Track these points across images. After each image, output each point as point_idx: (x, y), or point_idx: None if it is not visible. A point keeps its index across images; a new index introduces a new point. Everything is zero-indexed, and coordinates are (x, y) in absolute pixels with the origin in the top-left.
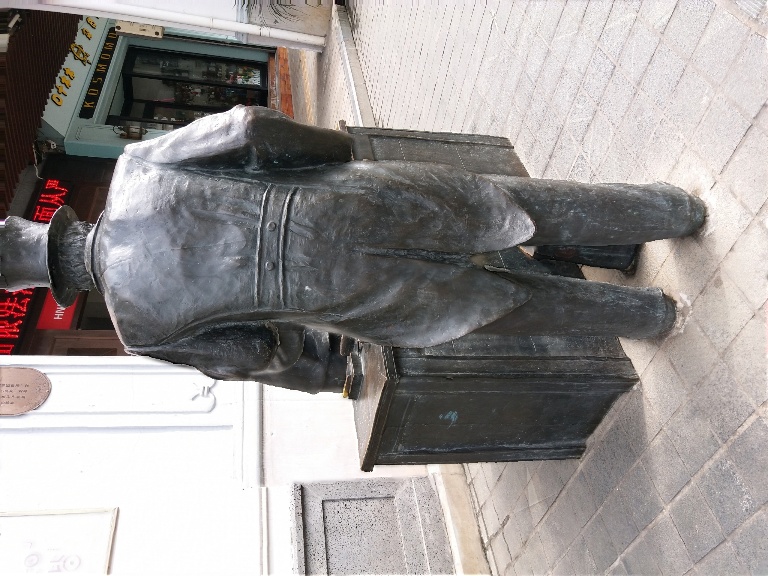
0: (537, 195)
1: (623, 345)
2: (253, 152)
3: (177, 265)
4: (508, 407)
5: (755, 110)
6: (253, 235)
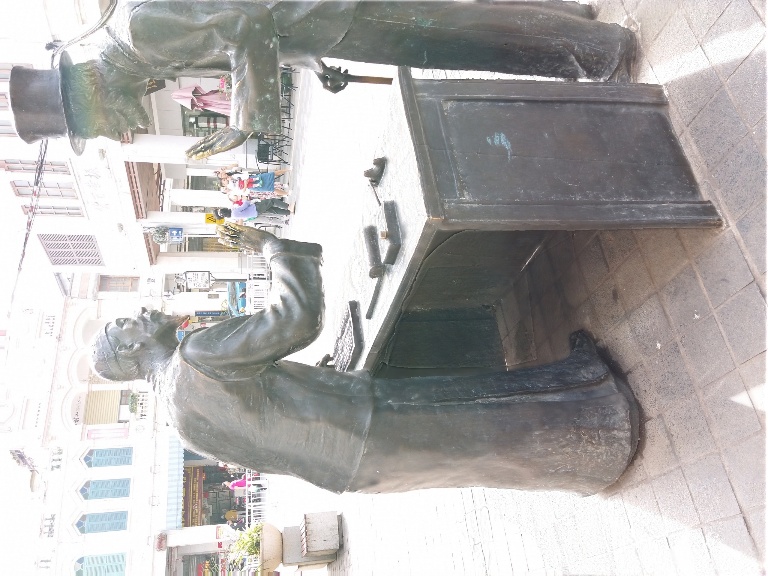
0: None
1: None
2: None
3: None
4: (559, 131)
5: None
6: None
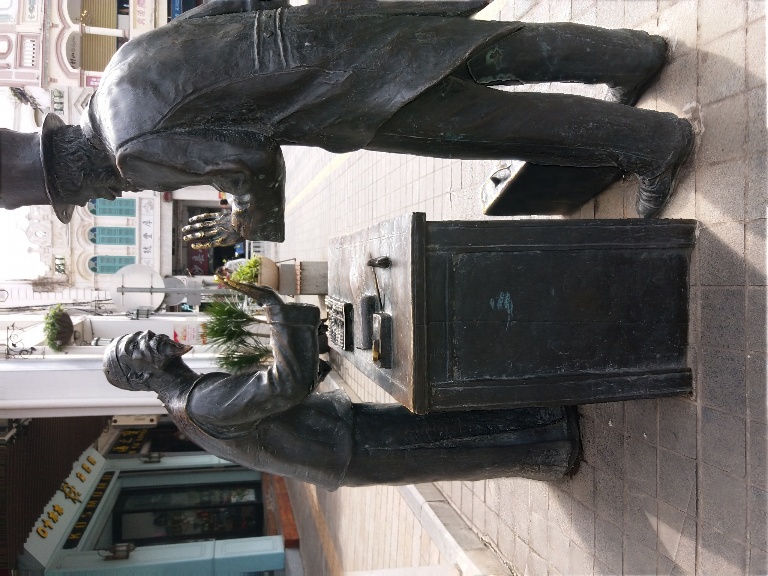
0: None
1: None
2: (247, 2)
3: (177, 50)
4: (567, 285)
5: None
6: (250, 23)
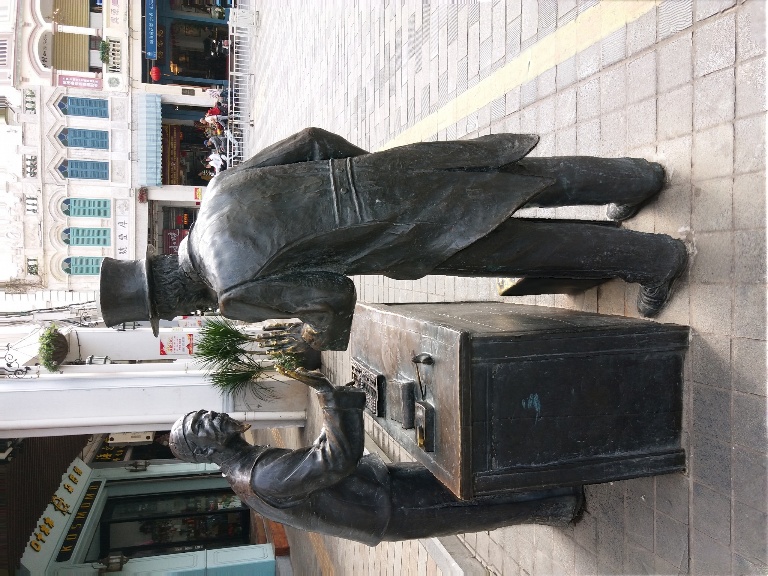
0: (532, 158)
1: (662, 321)
2: (315, 146)
3: (268, 205)
4: (584, 385)
5: (654, 90)
6: (327, 178)
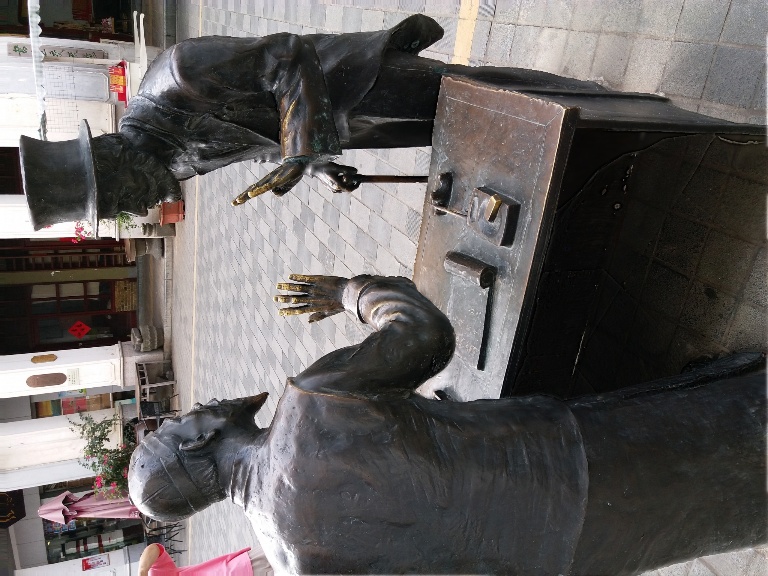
0: None
1: None
2: None
3: None
4: None
5: None
6: None
